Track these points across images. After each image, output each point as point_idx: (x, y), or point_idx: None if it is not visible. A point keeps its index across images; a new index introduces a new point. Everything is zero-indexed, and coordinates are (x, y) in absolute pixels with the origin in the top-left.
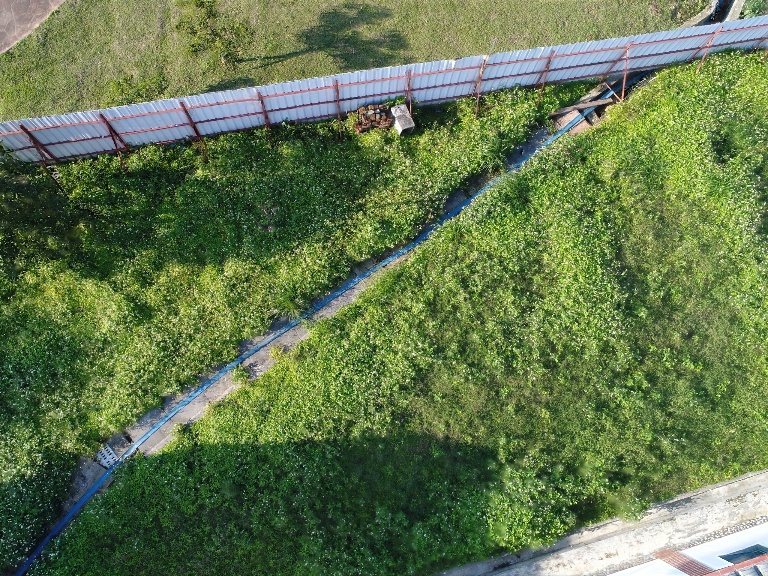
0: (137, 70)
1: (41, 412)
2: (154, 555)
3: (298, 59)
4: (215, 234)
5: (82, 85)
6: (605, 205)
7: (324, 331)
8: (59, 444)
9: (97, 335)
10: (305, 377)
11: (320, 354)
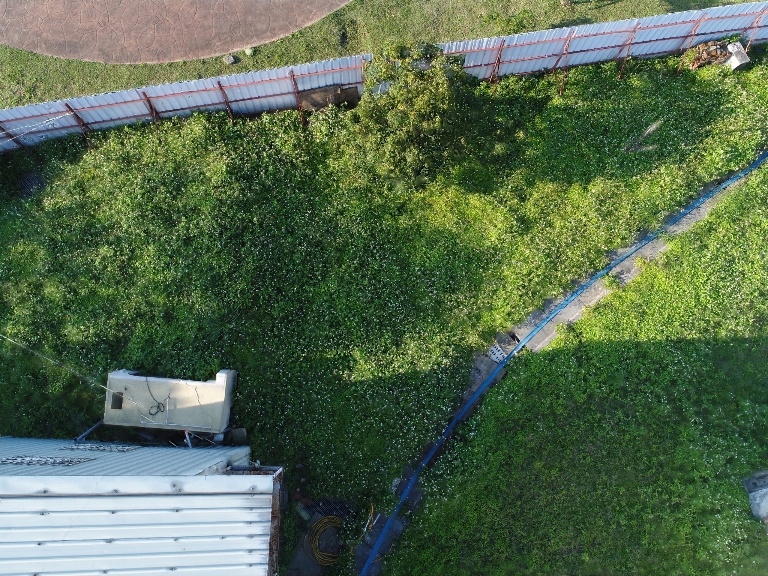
0: (485, 9)
1: (443, 310)
2: (551, 438)
3: (628, 2)
4: (577, 156)
5: (437, 22)
6: None
7: (686, 243)
8: (460, 339)
9: (487, 243)
10: (674, 283)
11: (687, 262)
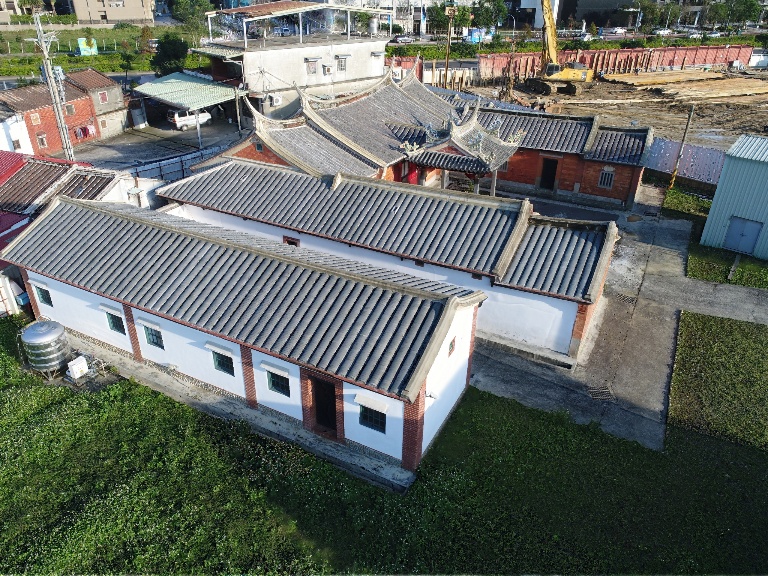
0: None
1: None
2: None
3: None
4: None
5: None
6: (8, 559)
7: None
8: None
9: None
10: None
11: None
